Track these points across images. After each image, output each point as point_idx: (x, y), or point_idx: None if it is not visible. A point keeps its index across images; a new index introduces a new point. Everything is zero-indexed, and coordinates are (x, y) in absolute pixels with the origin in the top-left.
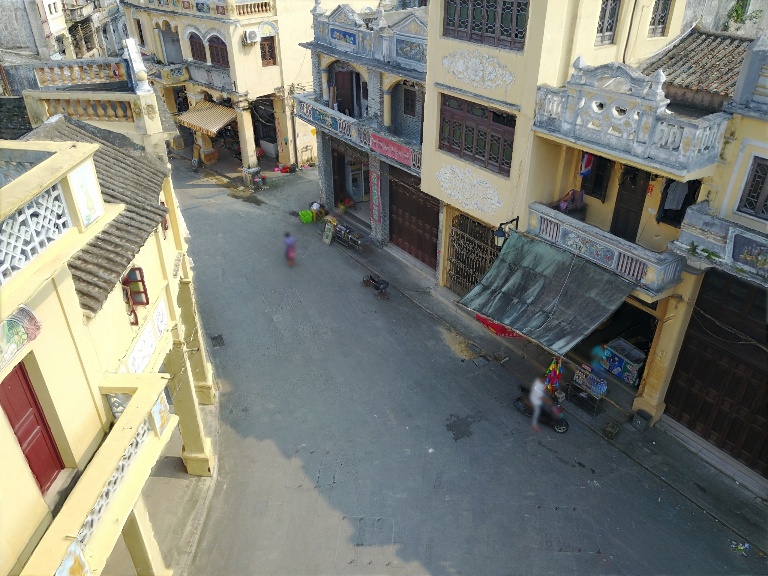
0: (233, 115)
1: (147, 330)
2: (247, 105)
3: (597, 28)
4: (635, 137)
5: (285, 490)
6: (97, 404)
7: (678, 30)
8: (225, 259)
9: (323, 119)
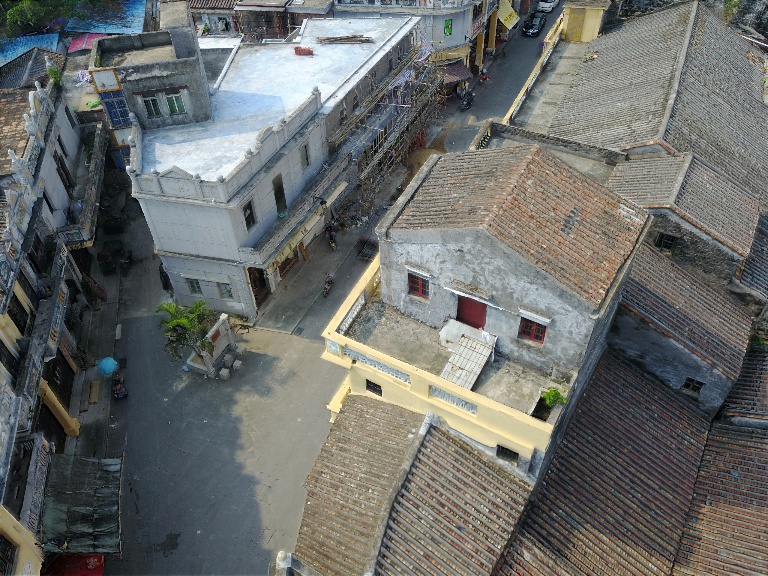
0: None
1: None
2: None
3: None
4: (8, 420)
5: (293, 535)
6: None
7: None
8: None
9: None
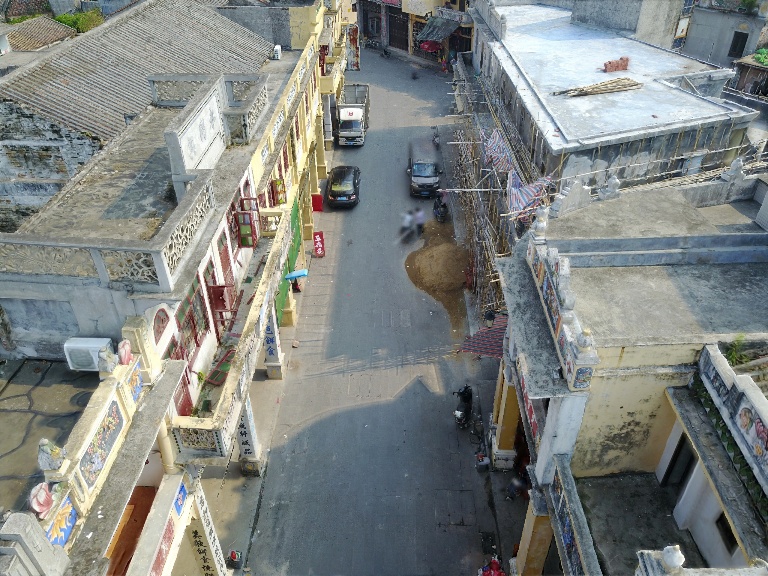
0: None
1: None
2: None
3: None
4: None
5: None
6: None
7: None
8: None
9: None
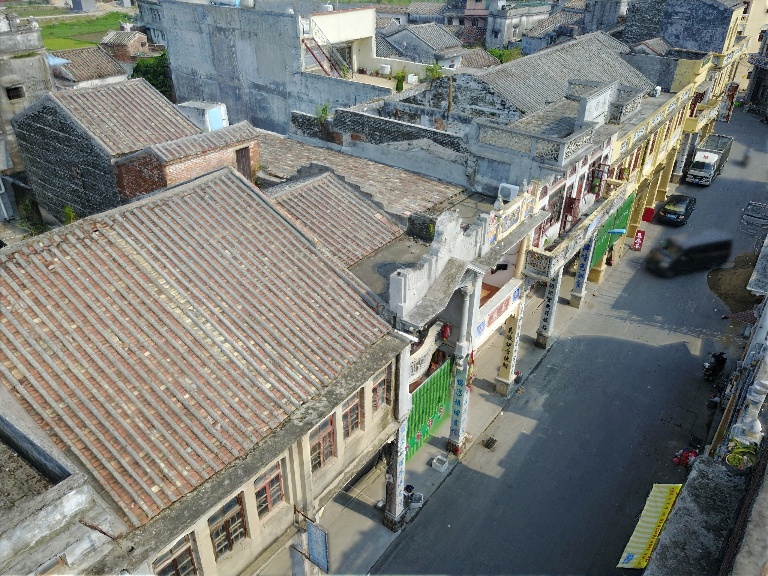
0: None
1: None
2: None
3: None
4: None
5: None
6: (724, 85)
7: None
8: None
9: (761, 62)
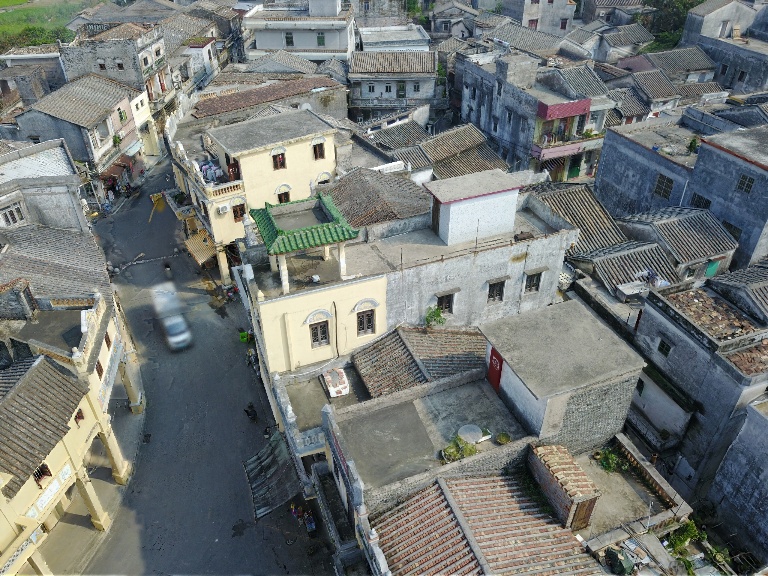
0: (215, 252)
1: (53, 484)
2: (222, 248)
3: (313, 341)
4: None
5: (136, 548)
6: (14, 529)
7: (385, 329)
8: (179, 369)
9: None
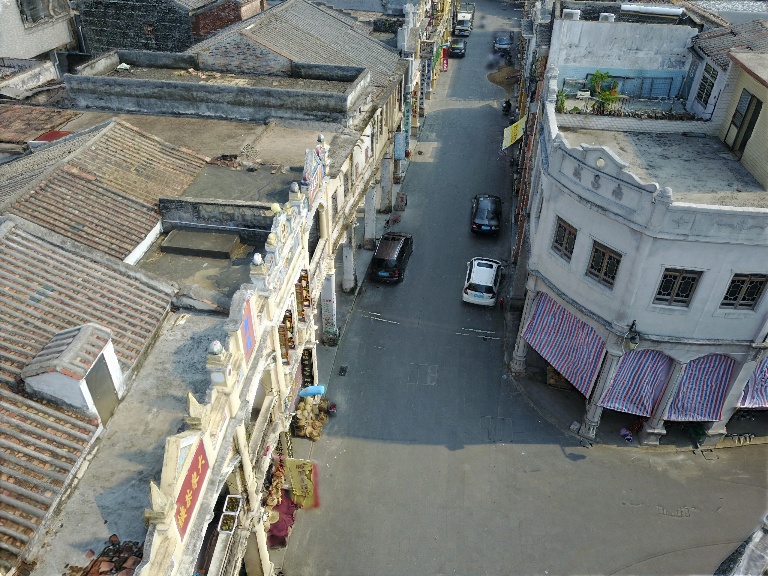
0: None
1: None
2: None
3: None
4: None
5: None
6: None
7: None
8: None
9: None
